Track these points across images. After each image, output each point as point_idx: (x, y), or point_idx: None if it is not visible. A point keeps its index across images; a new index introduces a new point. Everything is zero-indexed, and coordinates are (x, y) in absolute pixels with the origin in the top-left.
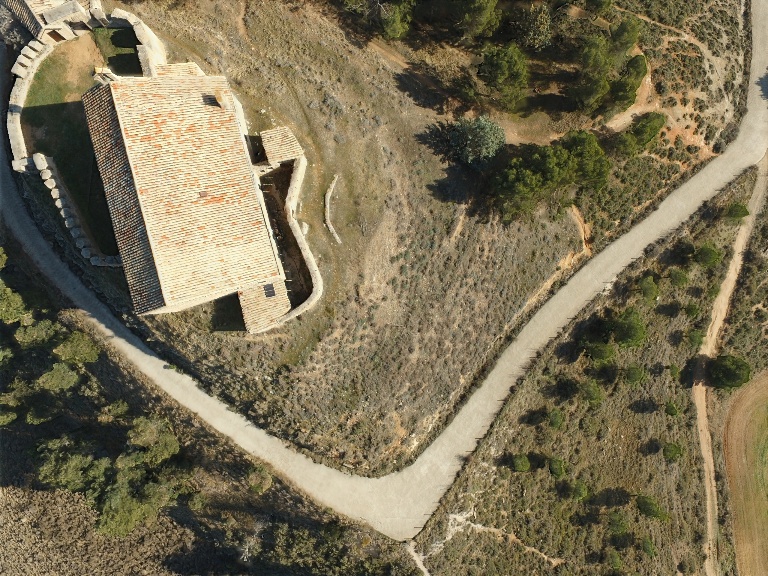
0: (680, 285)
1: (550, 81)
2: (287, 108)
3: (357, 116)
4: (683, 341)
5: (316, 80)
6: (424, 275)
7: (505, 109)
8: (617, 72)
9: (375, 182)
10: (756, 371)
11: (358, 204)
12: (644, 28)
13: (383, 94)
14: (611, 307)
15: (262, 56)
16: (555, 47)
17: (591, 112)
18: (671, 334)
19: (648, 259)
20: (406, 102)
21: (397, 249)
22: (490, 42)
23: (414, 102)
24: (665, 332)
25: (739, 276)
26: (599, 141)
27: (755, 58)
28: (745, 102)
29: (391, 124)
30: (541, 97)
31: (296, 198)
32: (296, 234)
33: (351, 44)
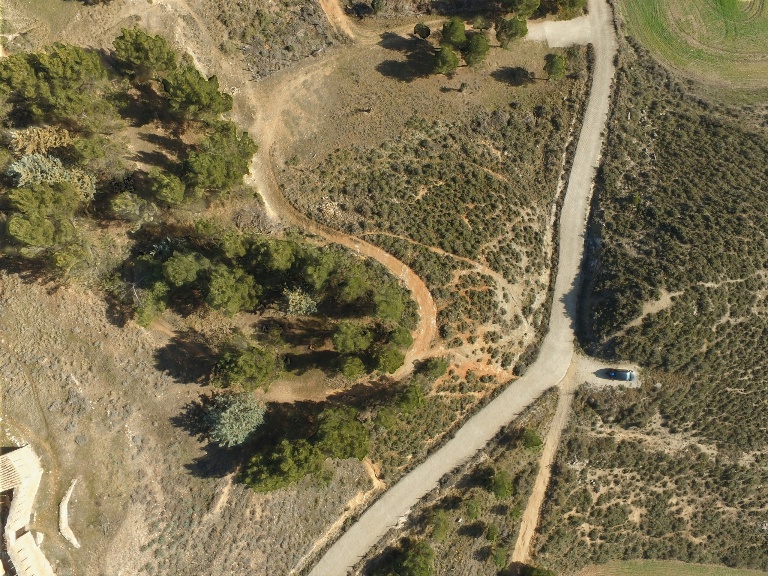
0: (483, 505)
1: (325, 337)
2: (25, 414)
3: (104, 410)
4: (492, 554)
5: (61, 377)
6: (186, 550)
7: (279, 368)
8: (396, 322)
9: (120, 478)
10: (576, 569)
11: (99, 505)
12: (434, 264)
13: (136, 380)
14: (408, 536)
15: (10, 350)
16: (332, 301)
17: (360, 374)
18: (477, 551)
19: (443, 489)
20: (163, 383)
21: (149, 537)
22: (266, 299)
23: (174, 379)
24: (469, 551)
25: (547, 488)
26: (378, 392)
27: (561, 273)
28: (548, 320)
29: (145, 409)
30: (316, 354)
31: (26, 513)
32: (14, 563)
33: (110, 323)
